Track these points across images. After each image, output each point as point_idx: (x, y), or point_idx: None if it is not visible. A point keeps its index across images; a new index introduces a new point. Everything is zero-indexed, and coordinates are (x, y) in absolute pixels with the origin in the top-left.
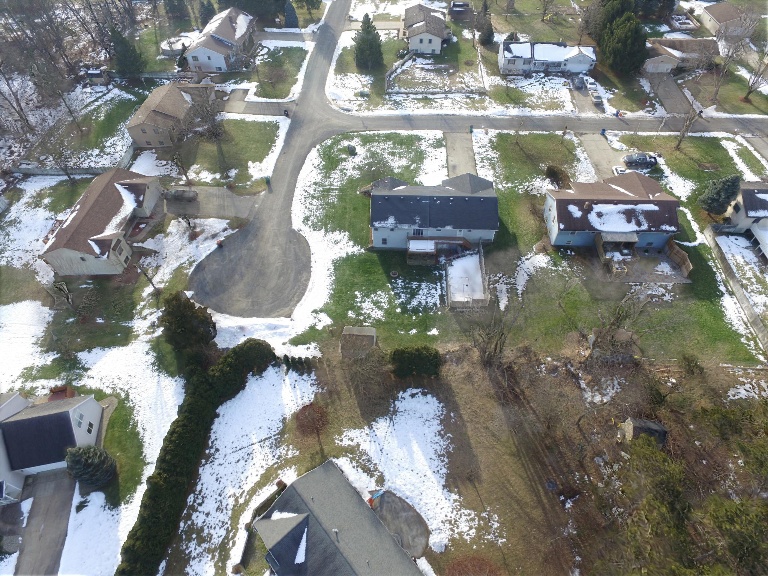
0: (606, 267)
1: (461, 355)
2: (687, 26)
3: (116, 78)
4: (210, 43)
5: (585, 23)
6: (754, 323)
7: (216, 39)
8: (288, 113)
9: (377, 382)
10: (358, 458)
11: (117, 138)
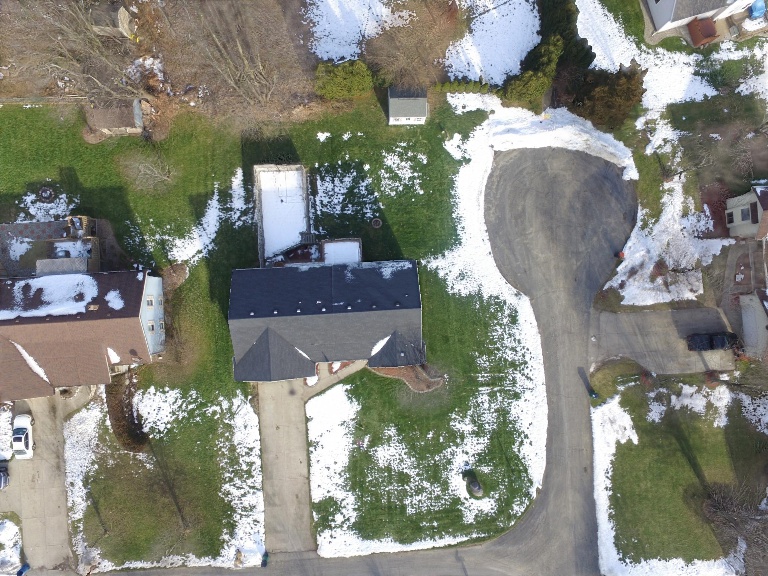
0: None
1: (291, 103)
2: None
3: None
4: None
5: None
6: None
7: None
8: None
9: None
10: None
11: None
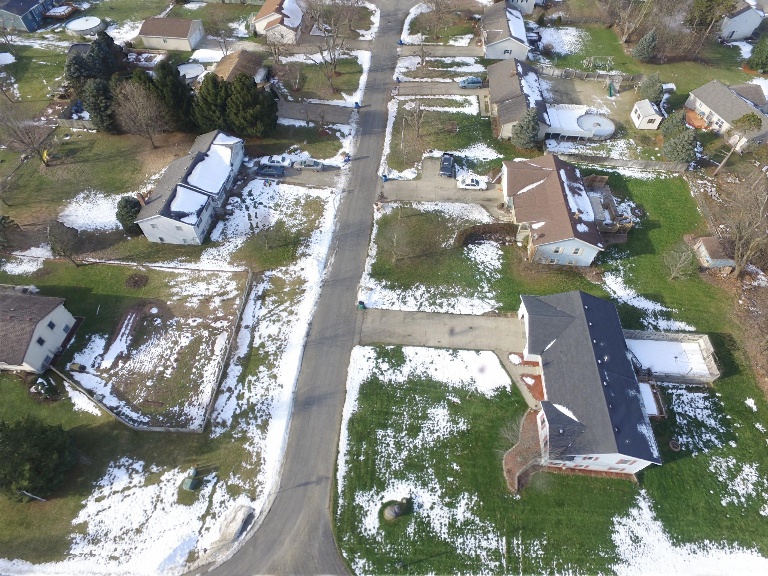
0: None
1: None
2: None
3: None
4: None
5: (151, 121)
6: (647, 166)
7: None
8: None
9: None
10: None
11: None
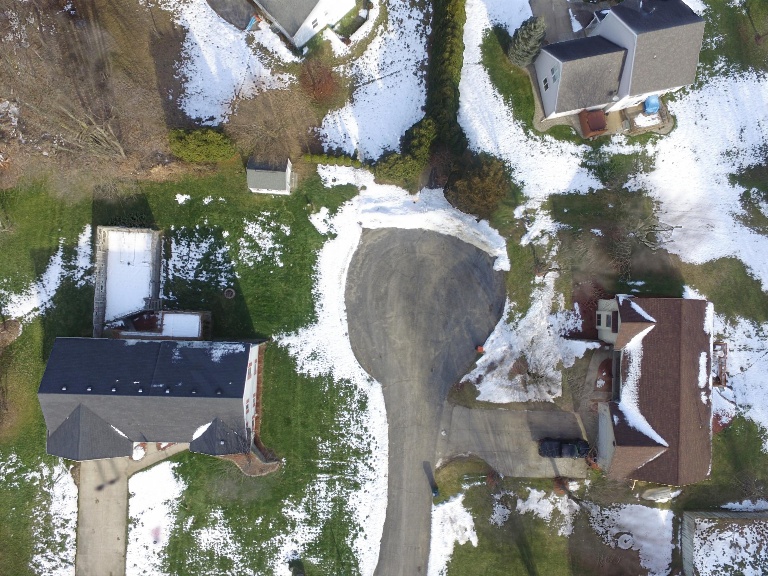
0: None
1: (150, 161)
2: None
3: None
4: None
5: None
6: None
7: None
8: None
9: None
10: (272, 61)
11: None
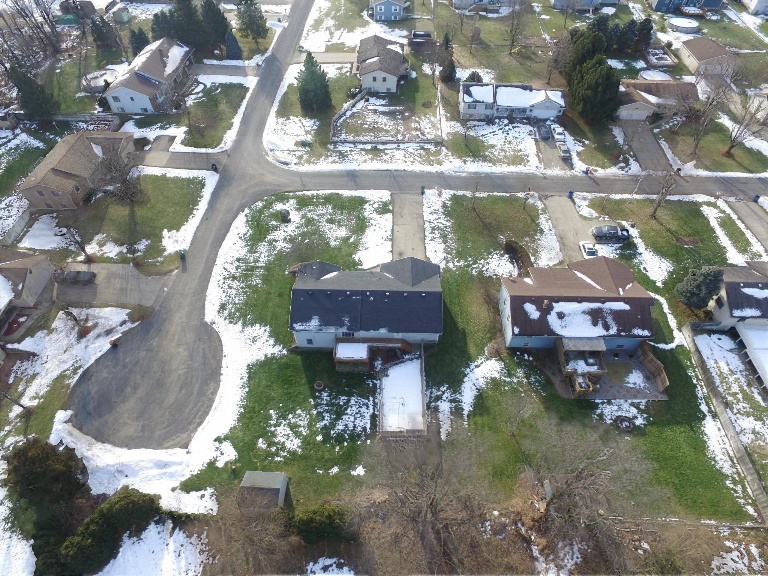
0: (568, 379)
1: (389, 508)
2: (664, 62)
3: (26, 120)
4: (133, 82)
5: (554, 62)
6: (741, 460)
7: (141, 77)
8: (217, 167)
9: (281, 551)
10: None
11: (14, 198)
